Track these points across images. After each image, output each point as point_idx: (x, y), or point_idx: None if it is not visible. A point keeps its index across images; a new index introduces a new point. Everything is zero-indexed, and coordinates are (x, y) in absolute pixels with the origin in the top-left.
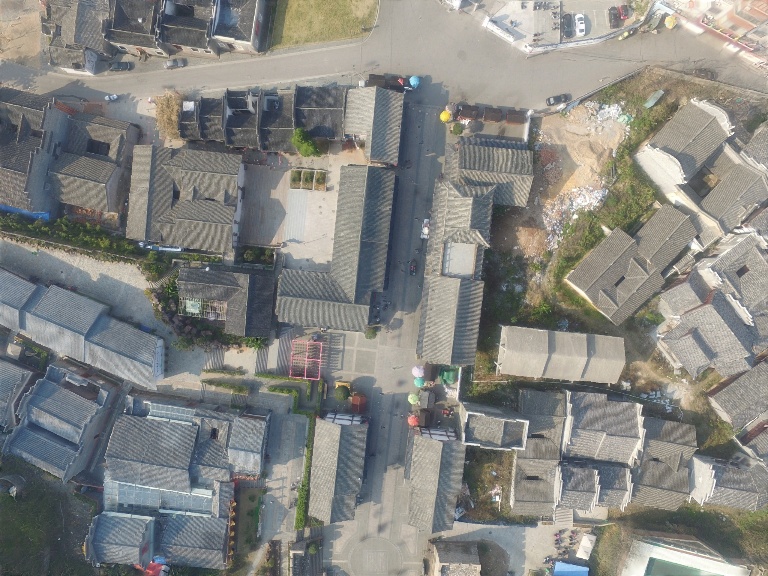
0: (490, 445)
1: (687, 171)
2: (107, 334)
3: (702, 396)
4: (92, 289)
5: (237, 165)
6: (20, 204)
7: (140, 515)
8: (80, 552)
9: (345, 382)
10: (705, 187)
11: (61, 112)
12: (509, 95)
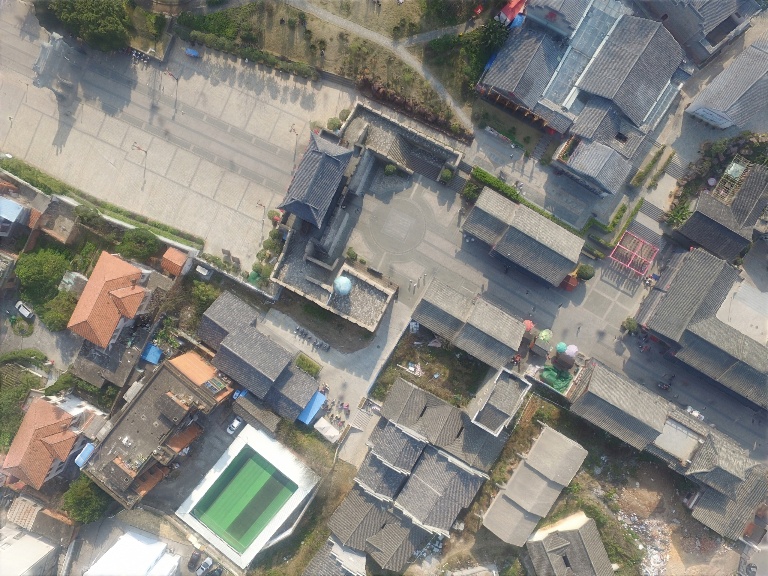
0: None
1: None
2: None
3: None
4: None
5: None
6: None
7: None
8: None
9: None
10: None
11: None
12: None
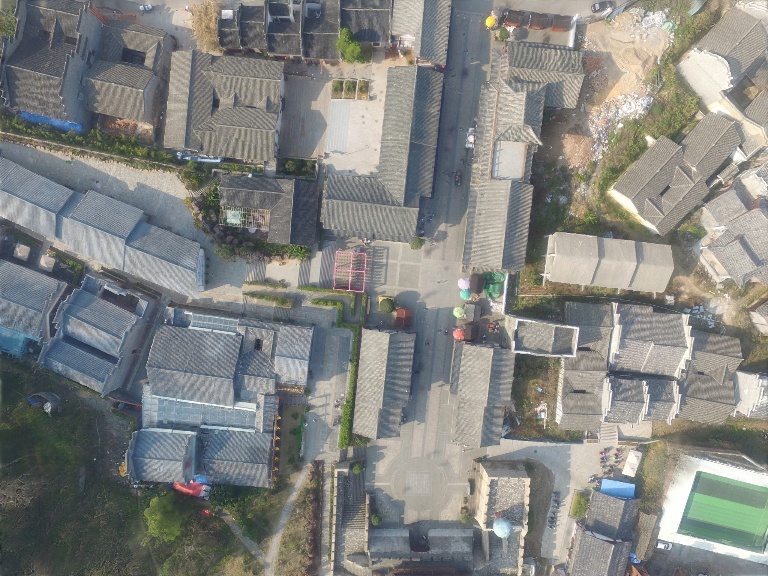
0: (540, 353)
1: (732, 76)
2: (148, 240)
3: (744, 311)
4: (129, 199)
5: (279, 71)
6: (53, 113)
7: (181, 430)
8: (117, 473)
9: (389, 297)
10: (745, 100)
11: (96, 19)
12: (554, 2)
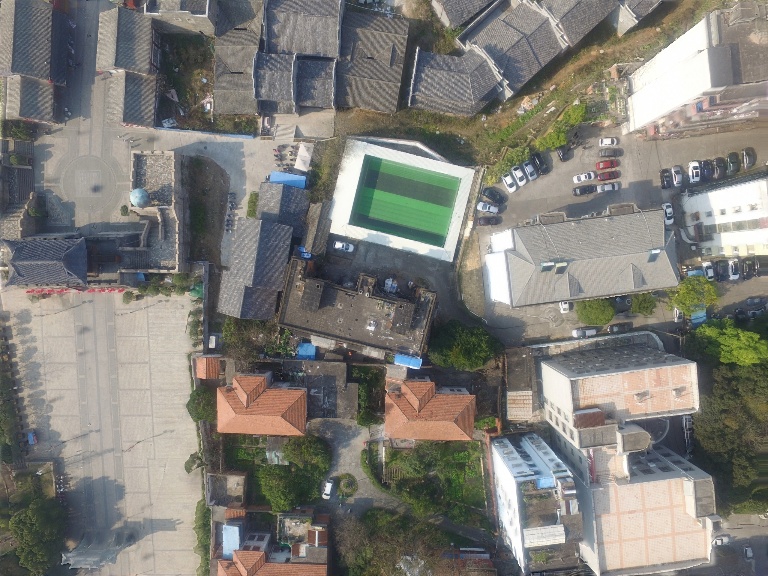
0: None
1: None
2: None
3: (424, 2)
4: None
5: None
6: None
7: None
8: None
9: None
10: None
11: None
12: None
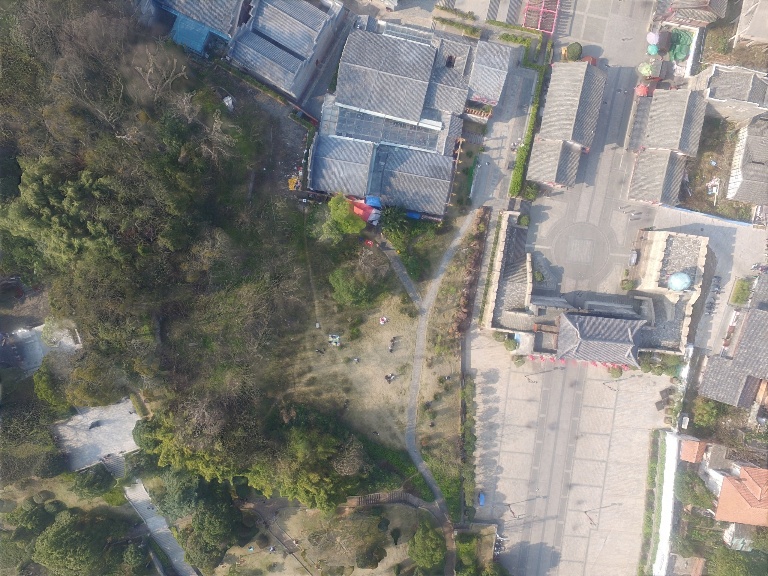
0: None
1: None
2: None
3: None
4: None
5: None
6: None
7: (363, 140)
8: (285, 186)
9: None
10: None
11: None
12: None
